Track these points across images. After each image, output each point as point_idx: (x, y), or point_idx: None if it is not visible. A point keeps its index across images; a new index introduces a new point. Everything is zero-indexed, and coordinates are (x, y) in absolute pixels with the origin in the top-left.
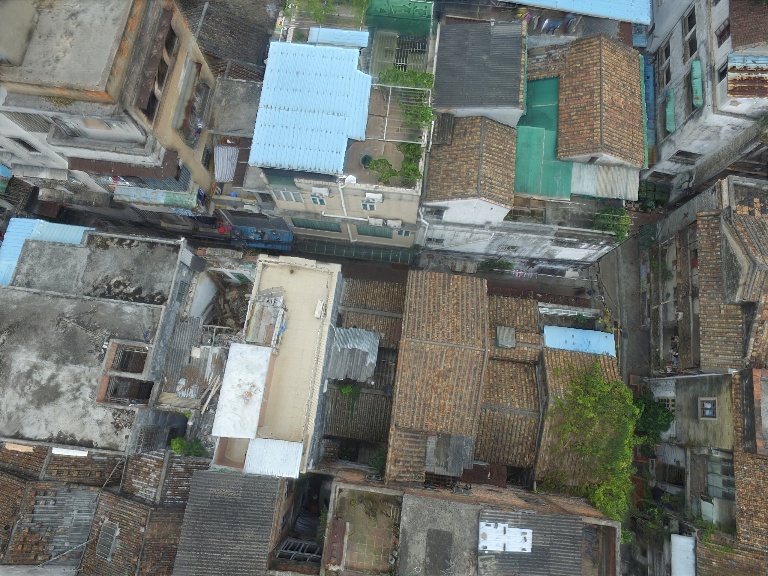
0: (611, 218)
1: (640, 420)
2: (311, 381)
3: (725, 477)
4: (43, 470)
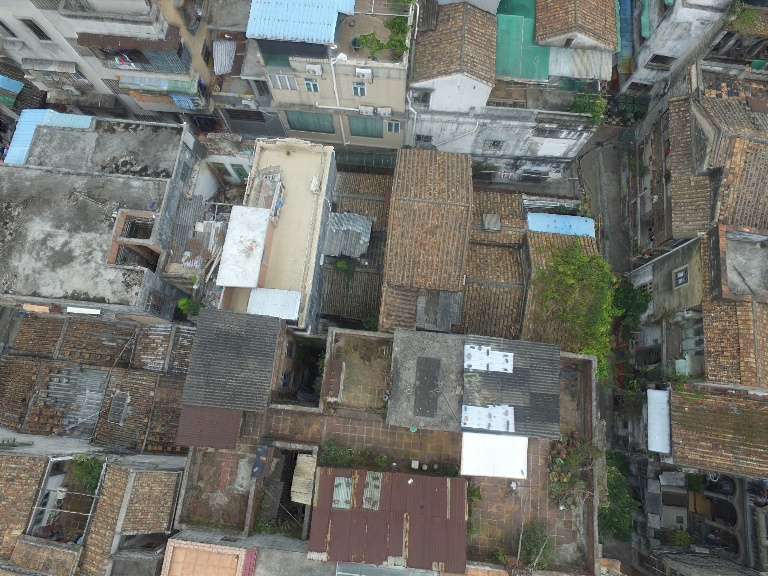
0: (587, 100)
1: (620, 305)
2: (308, 242)
3: (697, 337)
4: (56, 351)
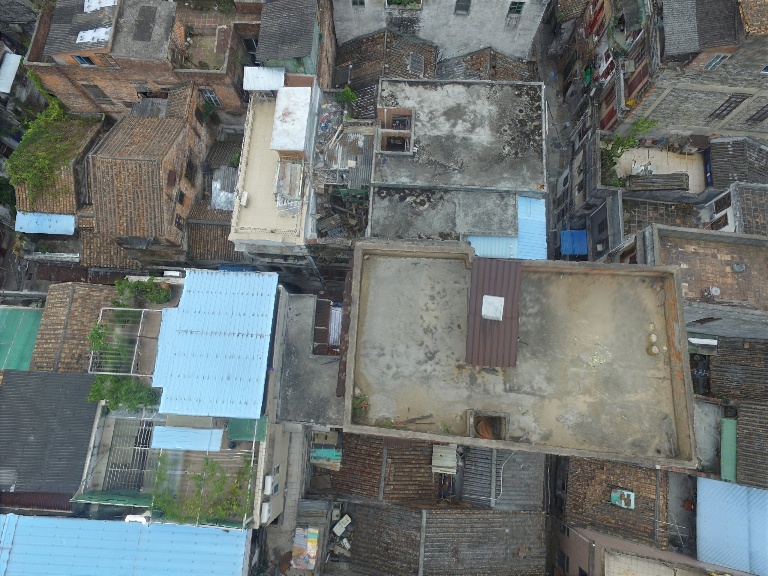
0: None
1: None
2: None
3: None
4: None
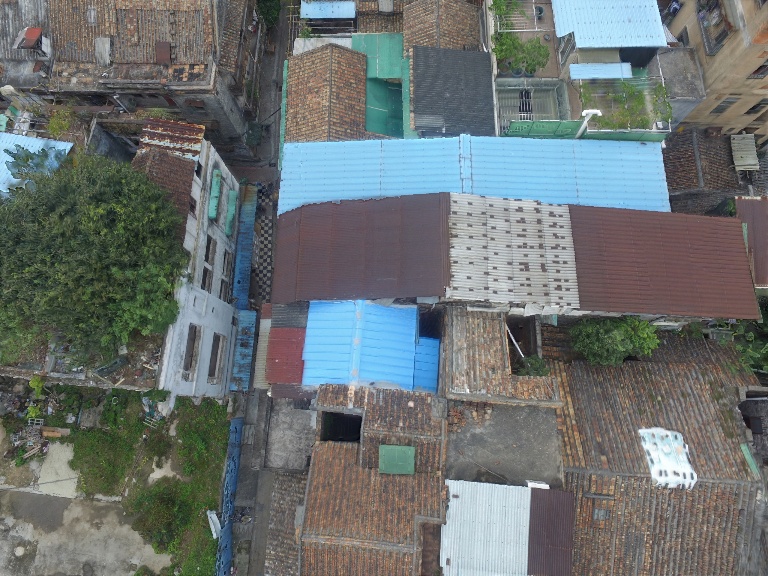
0: None
1: (276, 1)
2: None
3: None
4: None
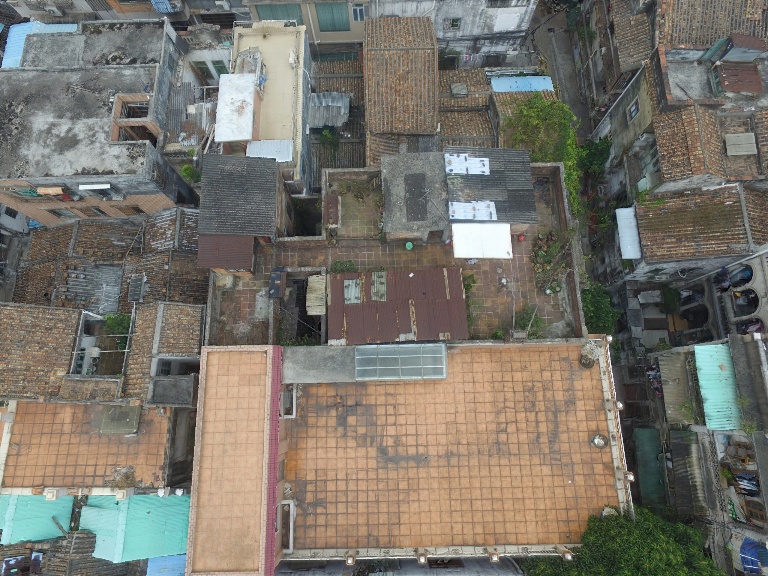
0: None
1: (586, 157)
2: (293, 103)
3: (654, 159)
4: (70, 250)
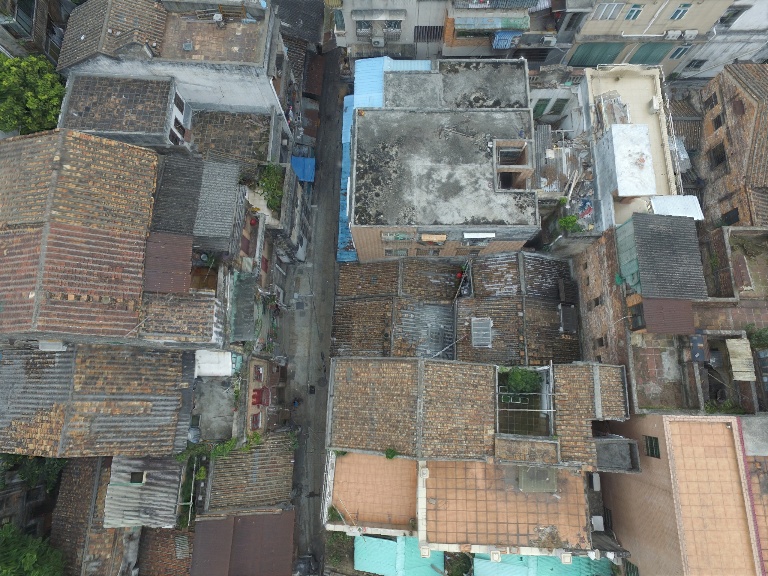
0: None
1: None
2: None
3: None
4: (400, 289)
